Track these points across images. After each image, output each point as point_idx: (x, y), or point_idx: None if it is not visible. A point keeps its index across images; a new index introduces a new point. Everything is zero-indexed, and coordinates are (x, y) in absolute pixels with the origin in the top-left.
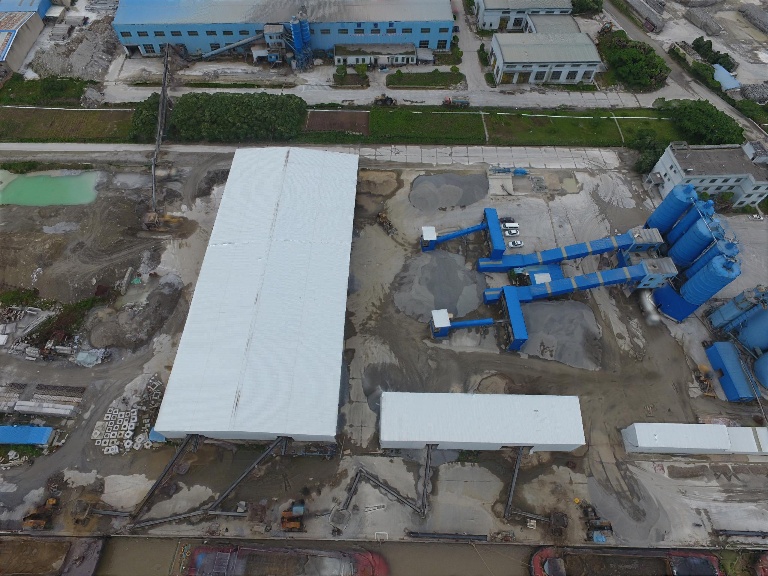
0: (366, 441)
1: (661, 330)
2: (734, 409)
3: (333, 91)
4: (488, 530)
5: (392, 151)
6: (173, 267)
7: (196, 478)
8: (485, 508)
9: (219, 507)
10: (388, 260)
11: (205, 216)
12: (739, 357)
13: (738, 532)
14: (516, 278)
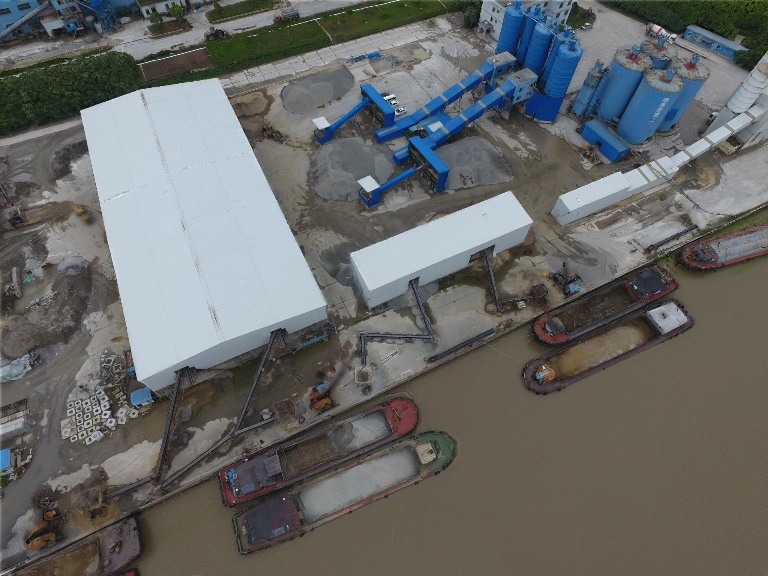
0: (353, 311)
1: (543, 133)
2: (619, 166)
3: (156, 41)
4: (490, 327)
5: (247, 75)
6: (66, 251)
7: (204, 417)
8: (480, 313)
9: (243, 427)
10: (293, 164)
11: (76, 193)
12: (606, 126)
13: (661, 242)
14: None
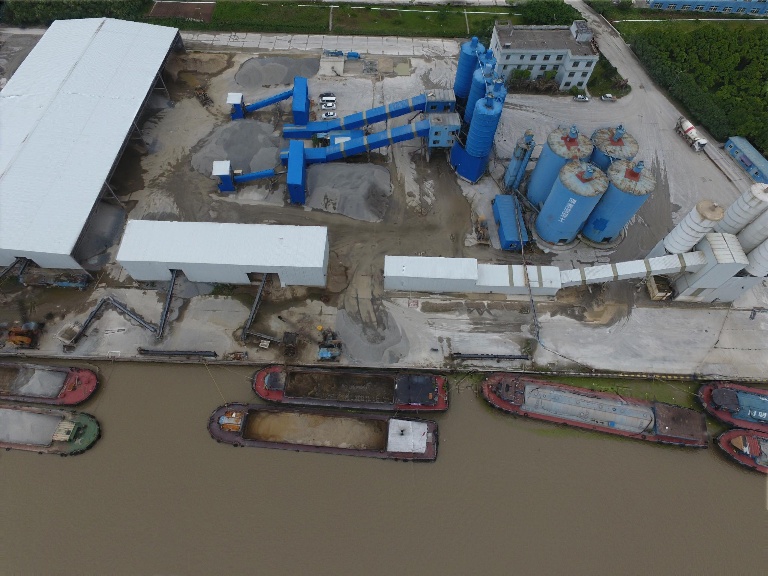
0: (124, 276)
1: (454, 190)
2: (506, 256)
3: None
4: (223, 351)
5: (231, 37)
6: None
7: None
8: (226, 333)
9: None
10: (196, 127)
11: None
12: (515, 207)
13: (472, 355)
14: (318, 143)
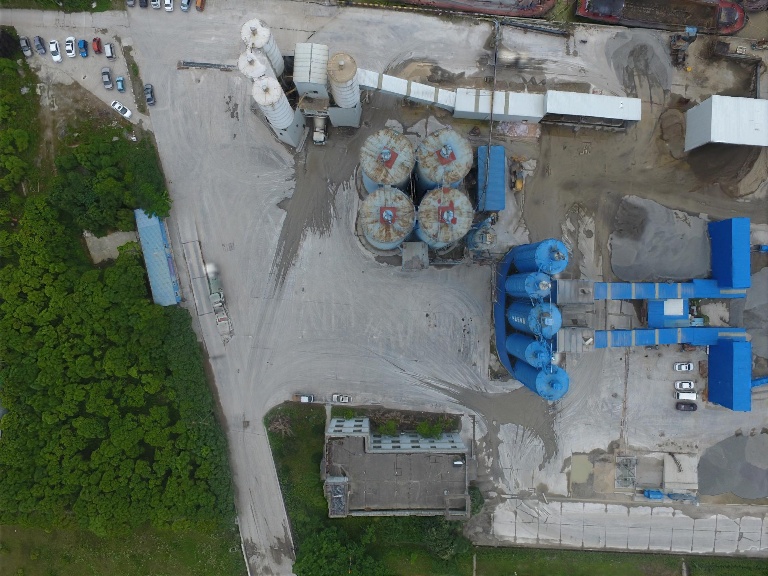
0: None
1: (539, 239)
2: None
3: None
4: None
5: None
6: None
7: None
8: None
9: None
10: None
11: None
12: None
13: (552, 31)
14: (699, 314)
